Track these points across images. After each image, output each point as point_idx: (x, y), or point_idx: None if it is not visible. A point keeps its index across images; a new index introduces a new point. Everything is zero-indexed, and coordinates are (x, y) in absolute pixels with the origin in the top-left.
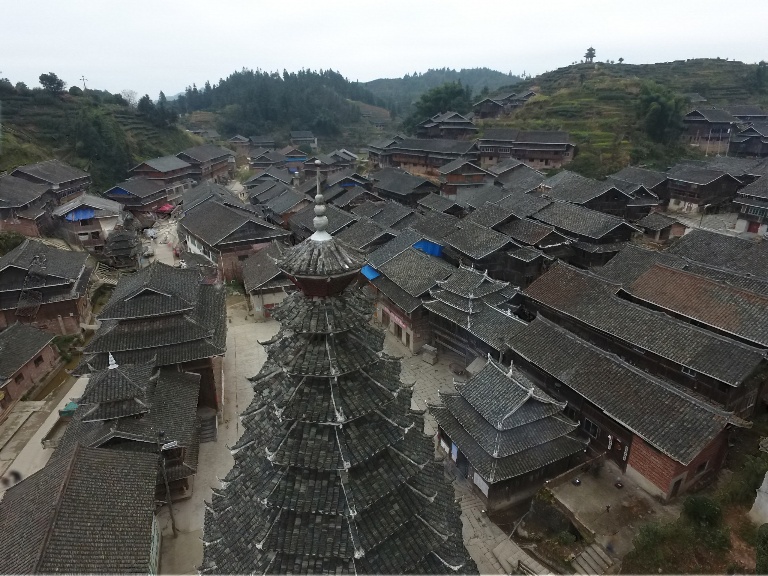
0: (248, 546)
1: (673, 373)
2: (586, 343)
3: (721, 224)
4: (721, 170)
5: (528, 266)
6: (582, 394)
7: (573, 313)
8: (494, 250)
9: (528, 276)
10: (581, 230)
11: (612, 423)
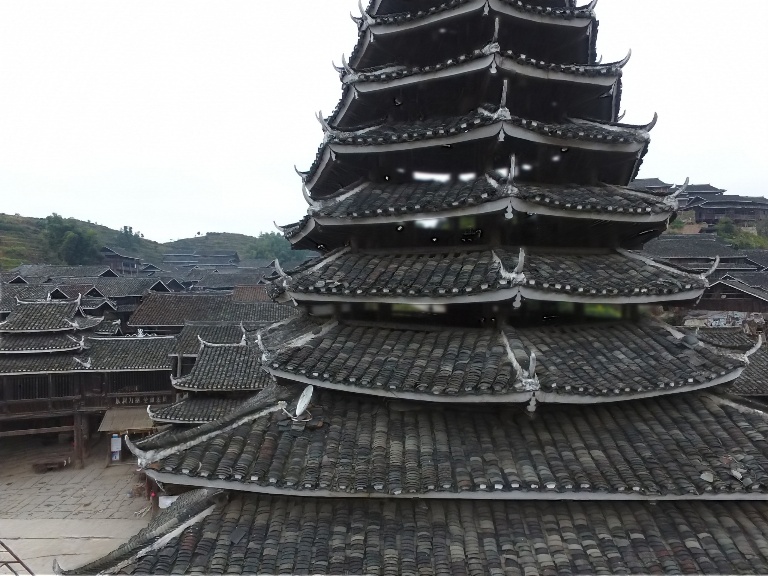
0: None
1: None
2: (262, 322)
3: None
4: (168, 276)
5: None
6: None
7: None
8: None
9: None
10: (115, 293)
11: None
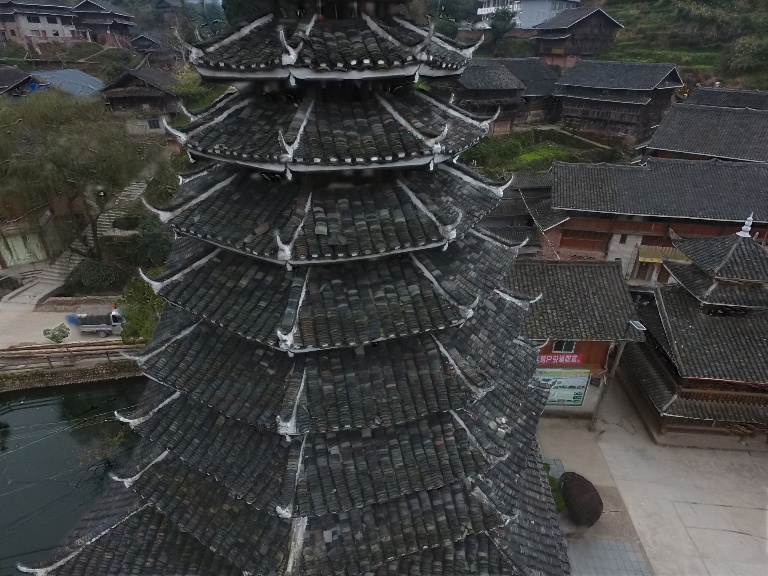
0: None
1: None
2: None
3: None
4: None
5: None
6: None
7: None
8: None
9: None
10: None
11: None
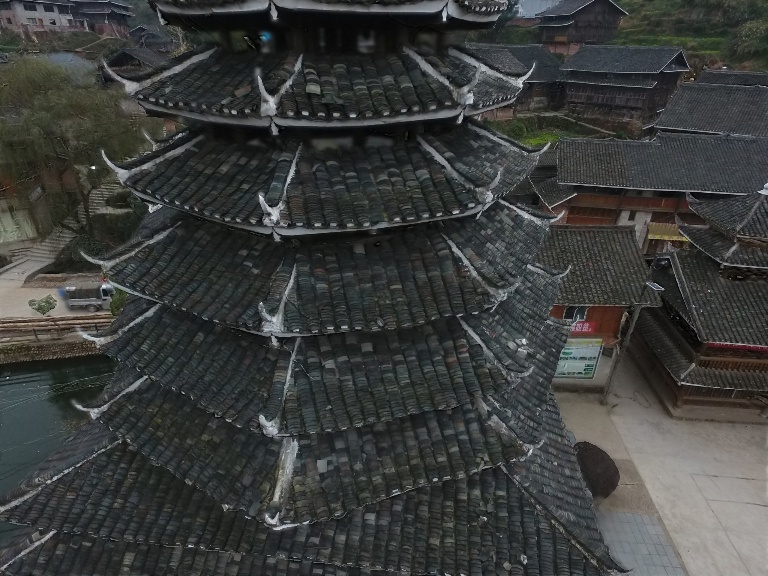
0: None
1: None
2: None
3: None
4: None
5: None
6: None
7: None
8: None
9: None
10: None
11: None
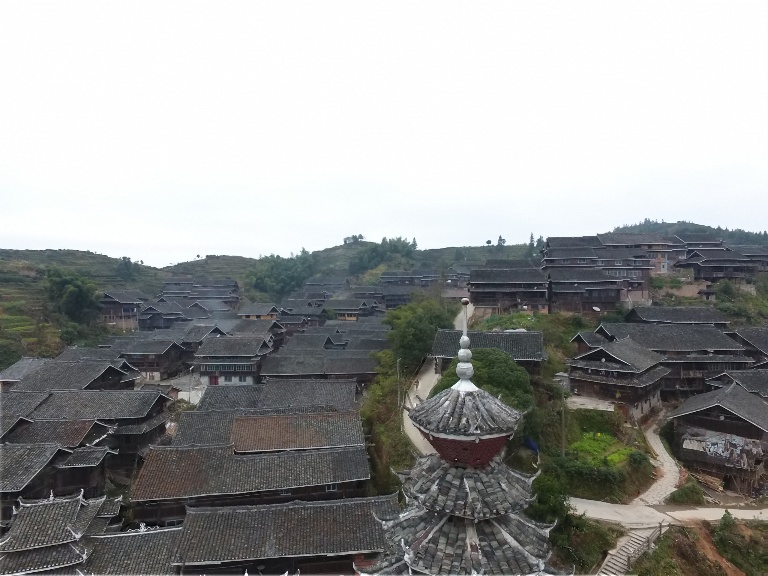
0: None
1: (323, 496)
2: (263, 507)
3: (198, 382)
4: (168, 340)
5: (92, 472)
6: (299, 554)
7: (211, 491)
8: (41, 468)
9: (95, 485)
10: (116, 414)
11: (331, 564)
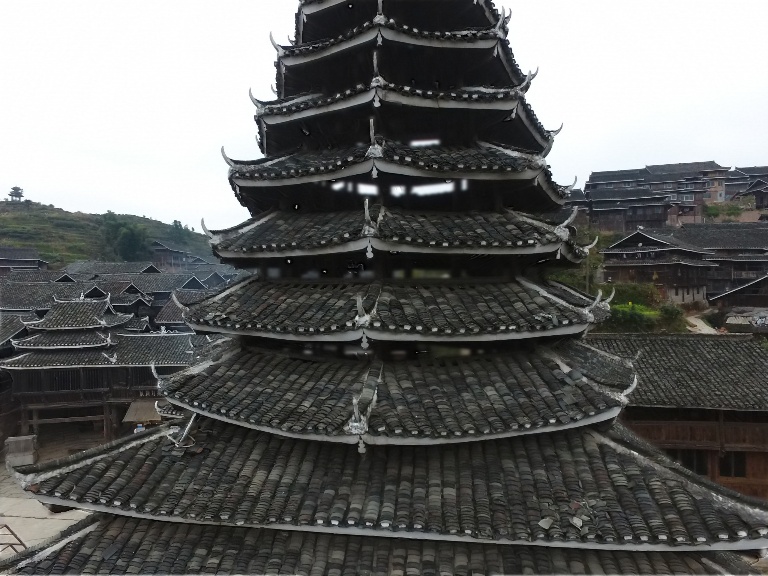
0: (481, 230)
1: None
2: None
3: None
4: (210, 270)
5: None
6: None
7: None
8: None
9: None
10: (153, 289)
11: None
